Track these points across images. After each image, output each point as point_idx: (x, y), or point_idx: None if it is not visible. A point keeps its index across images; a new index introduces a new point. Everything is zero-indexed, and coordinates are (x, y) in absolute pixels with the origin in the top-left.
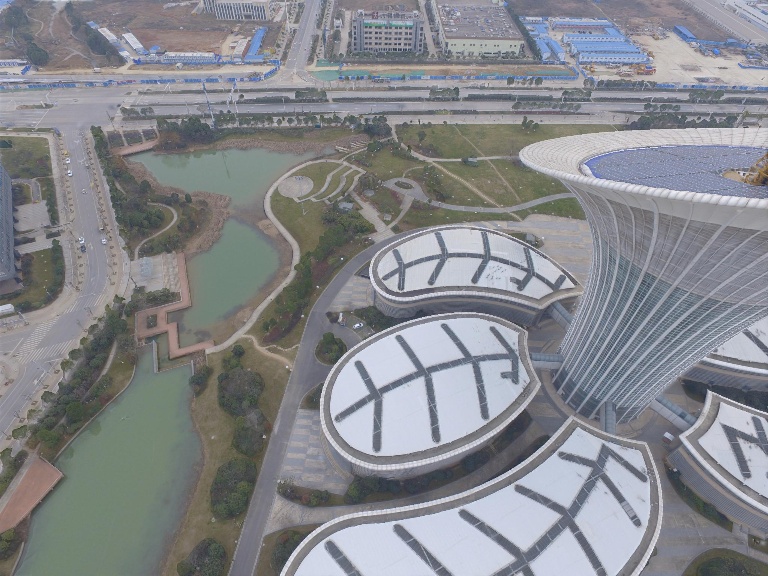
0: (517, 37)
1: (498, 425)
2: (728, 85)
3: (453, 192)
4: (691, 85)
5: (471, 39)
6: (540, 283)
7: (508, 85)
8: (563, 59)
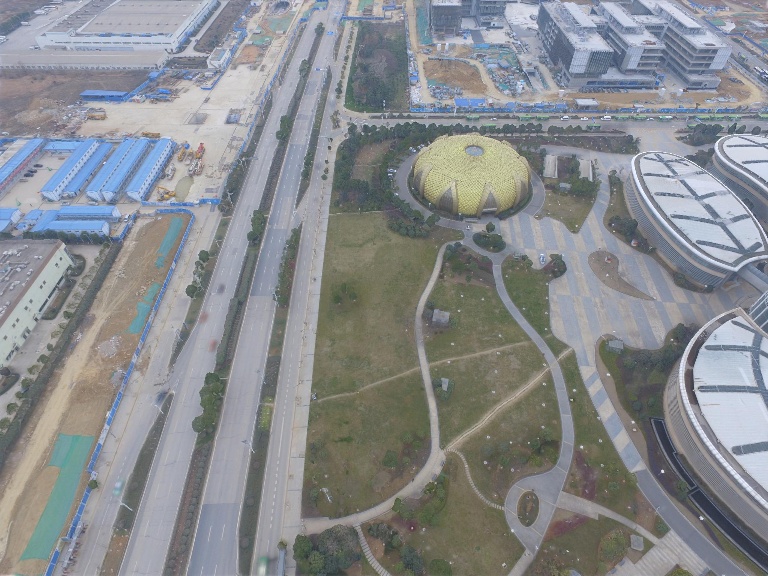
0: (46, 248)
1: None
2: (249, 109)
3: (532, 425)
4: (249, 131)
5: (5, 320)
6: (765, 345)
7: (193, 297)
8: (120, 214)
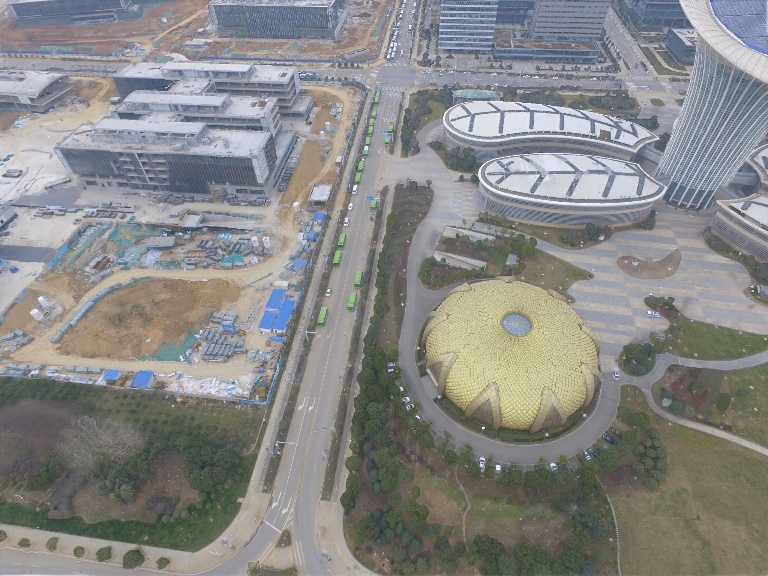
0: None
1: (766, 146)
2: None
3: None
4: None
5: None
6: (766, 203)
7: None
8: None
